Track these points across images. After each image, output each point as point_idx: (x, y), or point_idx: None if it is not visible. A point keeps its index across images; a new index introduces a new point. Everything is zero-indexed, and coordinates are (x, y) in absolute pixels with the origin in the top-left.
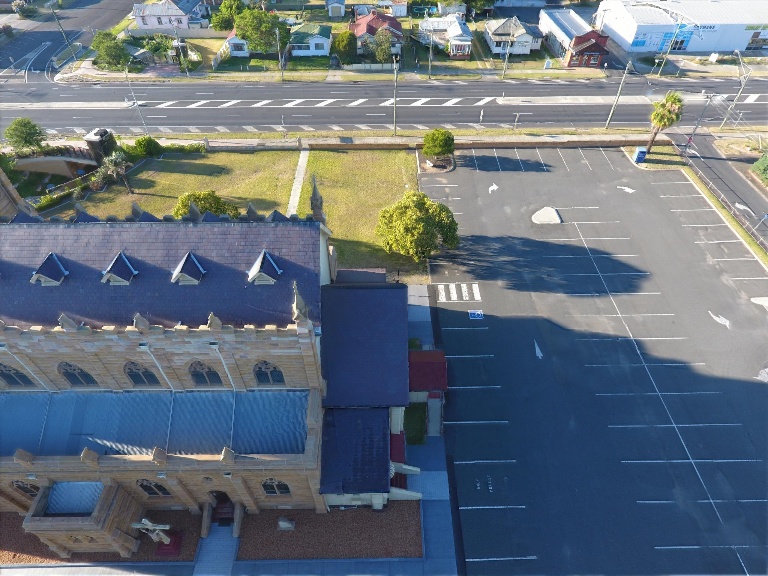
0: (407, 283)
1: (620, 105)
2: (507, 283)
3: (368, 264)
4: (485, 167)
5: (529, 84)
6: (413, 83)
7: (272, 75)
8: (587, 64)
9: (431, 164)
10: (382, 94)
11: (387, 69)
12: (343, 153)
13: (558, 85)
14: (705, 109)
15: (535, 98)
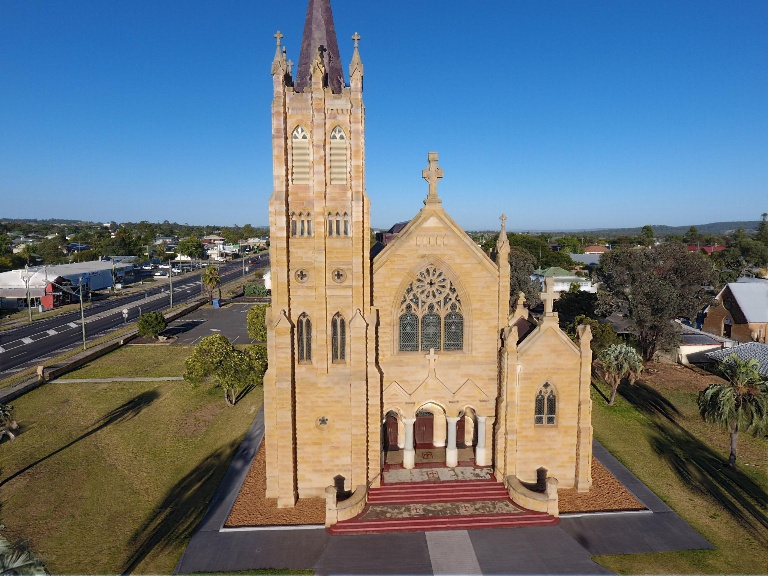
0: None
1: (145, 303)
2: None
3: None
4: (184, 330)
5: (63, 316)
6: None
7: None
8: (64, 303)
9: (165, 338)
10: None
11: None
12: (88, 366)
13: None
14: (219, 273)
15: None
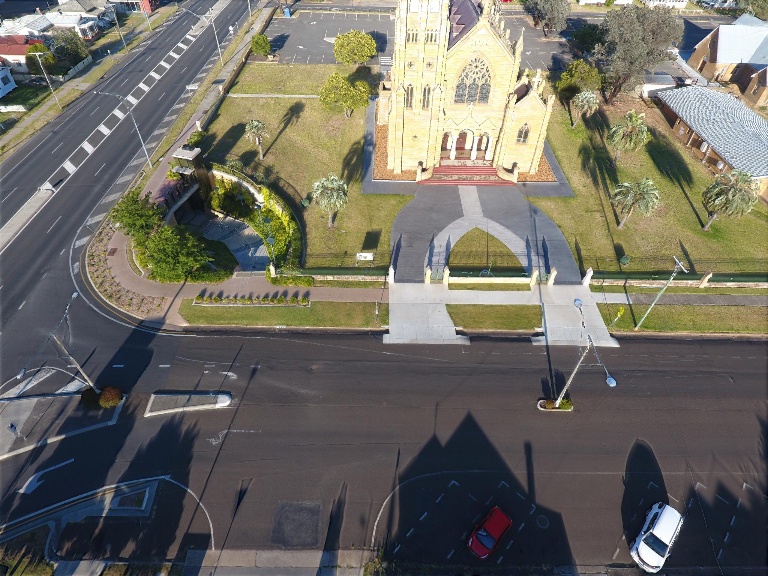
0: (379, 70)
1: (225, 9)
2: (380, 52)
3: (364, 77)
4: (279, 47)
5: (171, 25)
6: (132, 56)
7: (38, 115)
8: (156, 6)
9: (272, 56)
10: (146, 67)
11: (87, 64)
12: (239, 83)
13: (180, 18)
14: None
15: (198, 25)
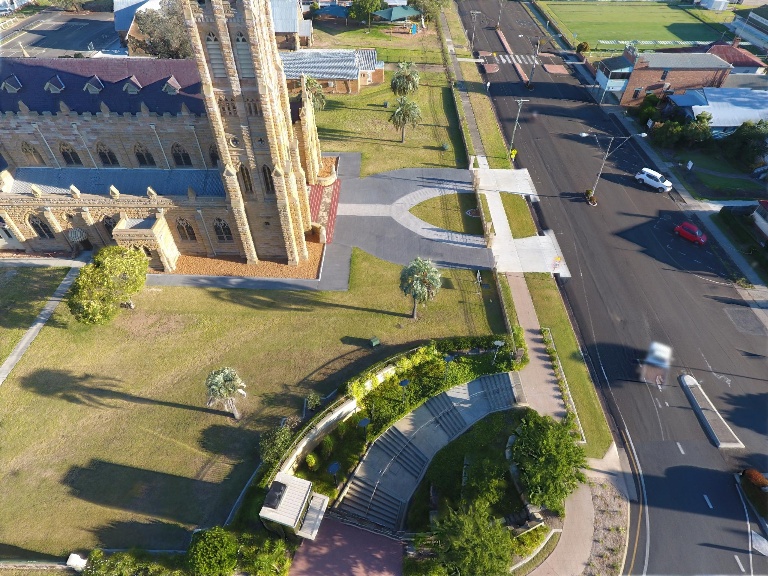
0: None
1: None
2: None
3: None
4: None
5: None
6: None
7: None
8: None
9: None
10: None
11: None
12: None
13: None
14: None
15: None
